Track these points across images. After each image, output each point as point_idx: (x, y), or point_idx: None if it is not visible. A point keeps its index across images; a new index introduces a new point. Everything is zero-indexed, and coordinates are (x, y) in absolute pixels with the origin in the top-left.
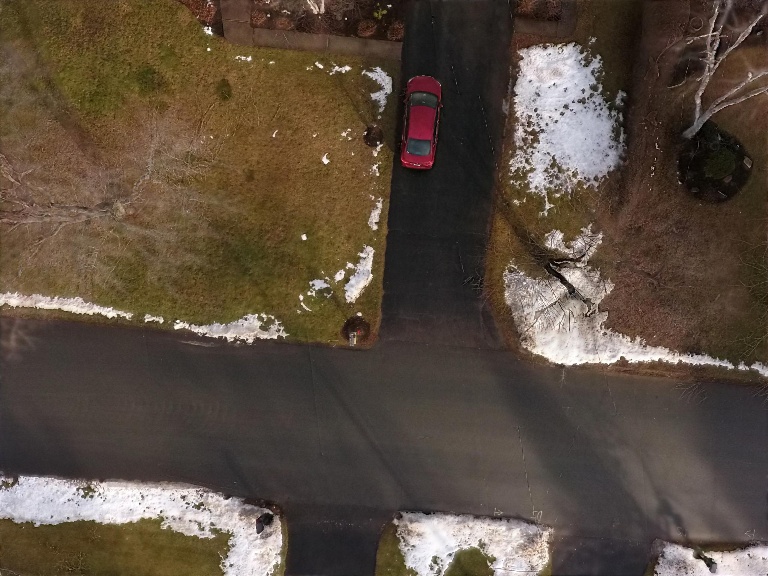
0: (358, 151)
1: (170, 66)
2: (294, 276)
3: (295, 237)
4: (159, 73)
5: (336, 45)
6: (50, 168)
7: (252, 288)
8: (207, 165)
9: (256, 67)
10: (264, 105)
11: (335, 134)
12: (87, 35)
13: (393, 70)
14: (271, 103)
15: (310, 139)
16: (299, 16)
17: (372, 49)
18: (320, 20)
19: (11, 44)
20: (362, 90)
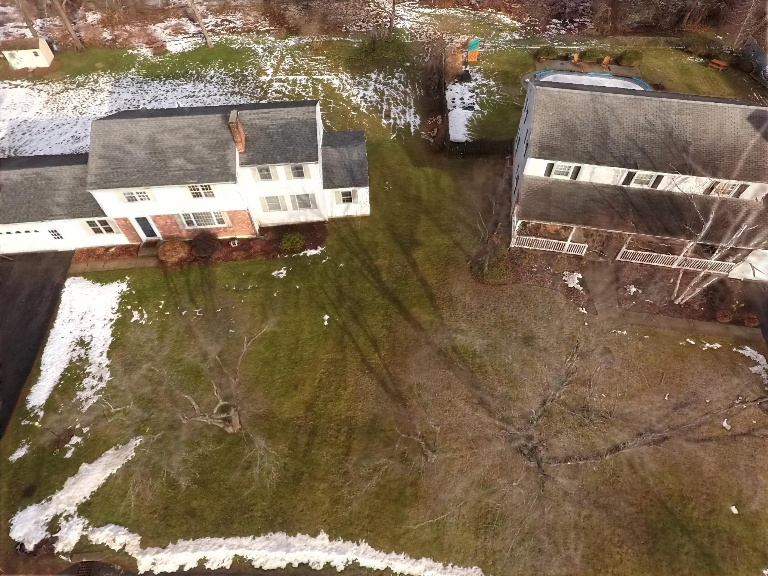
0: (758, 419)
1: (553, 334)
2: (741, 561)
3: (724, 509)
4: (544, 339)
5: (701, 327)
6: (444, 413)
7: (694, 573)
8: (605, 421)
9: (632, 339)
10: (649, 370)
11: (728, 401)
12: (475, 308)
13: (762, 350)
14: (655, 369)
15: (704, 404)
16: (662, 304)
17: (735, 332)
18: (682, 308)
19: (408, 311)
20: (739, 364)
